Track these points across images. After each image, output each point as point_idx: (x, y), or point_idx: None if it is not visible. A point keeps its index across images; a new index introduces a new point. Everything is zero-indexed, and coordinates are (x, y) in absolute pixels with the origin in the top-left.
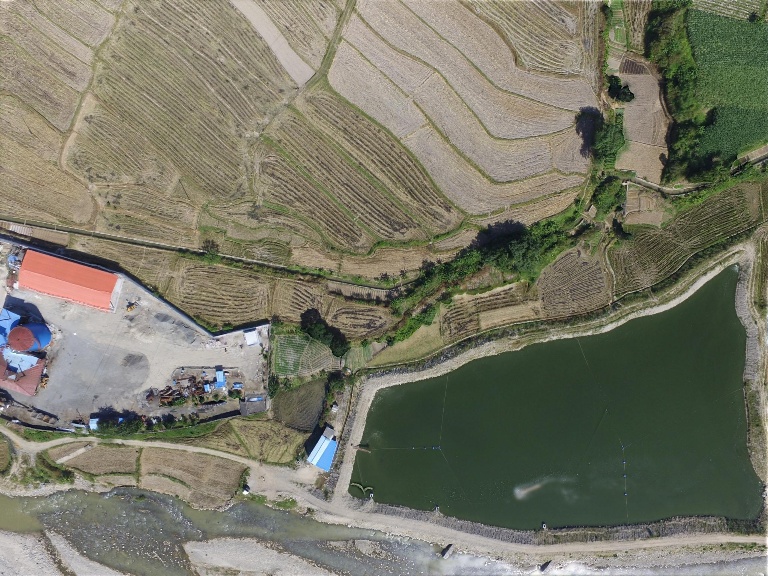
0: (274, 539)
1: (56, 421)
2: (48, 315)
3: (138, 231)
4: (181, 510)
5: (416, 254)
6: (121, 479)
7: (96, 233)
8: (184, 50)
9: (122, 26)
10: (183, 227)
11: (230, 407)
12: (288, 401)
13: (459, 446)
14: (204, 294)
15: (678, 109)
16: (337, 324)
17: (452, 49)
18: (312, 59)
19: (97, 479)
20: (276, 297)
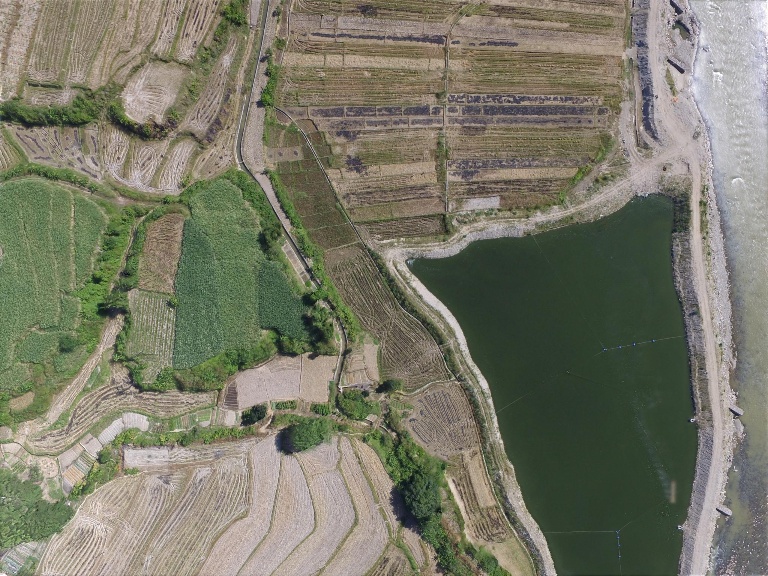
0: None
1: None
2: None
3: None
4: None
5: None
6: None
7: None
8: None
9: None
10: None
11: None
12: None
13: (614, 513)
14: None
15: None
16: None
17: (240, 575)
18: None
19: None
20: None
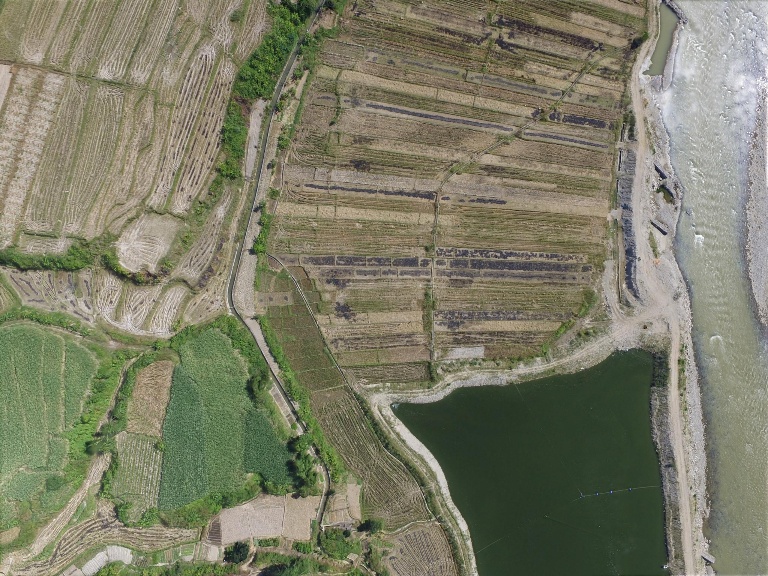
0: None
1: None
2: None
3: None
4: None
5: None
6: None
7: None
8: None
9: None
10: None
11: None
12: None
13: None
14: None
15: None
16: None
17: None
18: None
19: None
20: None
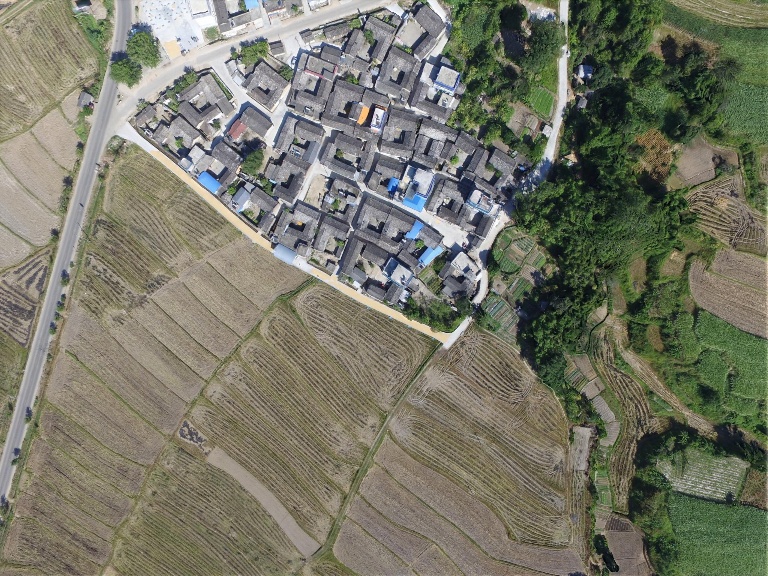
0: None
1: None
2: None
3: None
4: None
5: None
6: None
7: None
8: (198, 527)
9: (141, 508)
10: None
11: None
12: None
13: None
14: None
15: (660, 571)
16: None
17: (449, 524)
18: (318, 535)
19: None
20: None
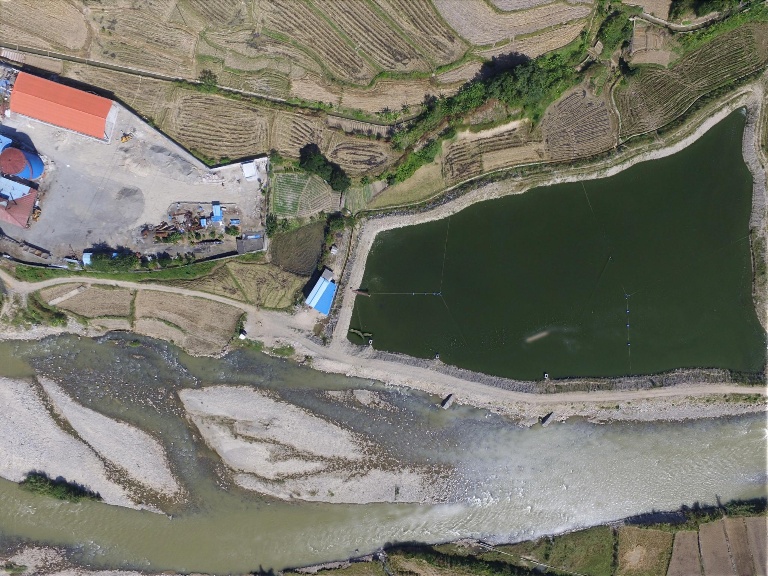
0: (271, 388)
1: (48, 256)
2: (41, 145)
3: (133, 59)
4: (176, 356)
5: (418, 88)
6: (115, 322)
7: (90, 61)
8: None
9: None
10: (180, 55)
11: (227, 248)
12: (286, 244)
13: (460, 292)
14: (201, 126)
15: None
16: (337, 160)
17: None
18: None
19: (90, 322)
20: (275, 131)
